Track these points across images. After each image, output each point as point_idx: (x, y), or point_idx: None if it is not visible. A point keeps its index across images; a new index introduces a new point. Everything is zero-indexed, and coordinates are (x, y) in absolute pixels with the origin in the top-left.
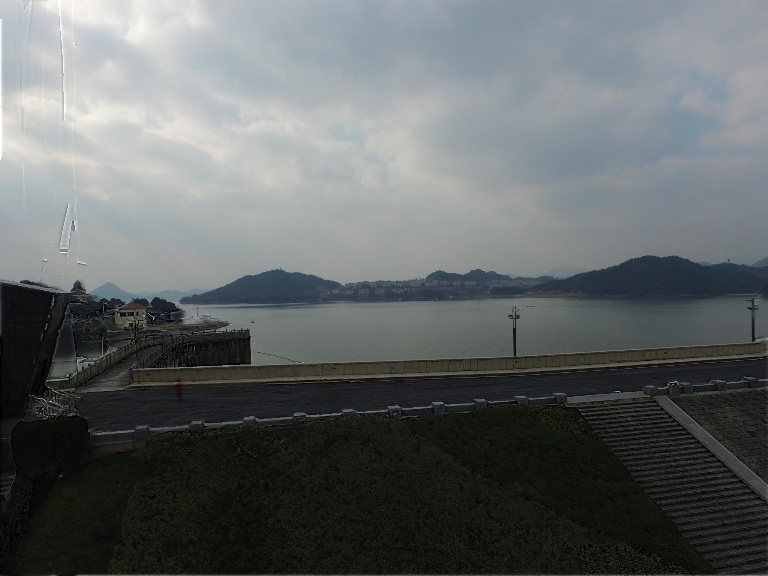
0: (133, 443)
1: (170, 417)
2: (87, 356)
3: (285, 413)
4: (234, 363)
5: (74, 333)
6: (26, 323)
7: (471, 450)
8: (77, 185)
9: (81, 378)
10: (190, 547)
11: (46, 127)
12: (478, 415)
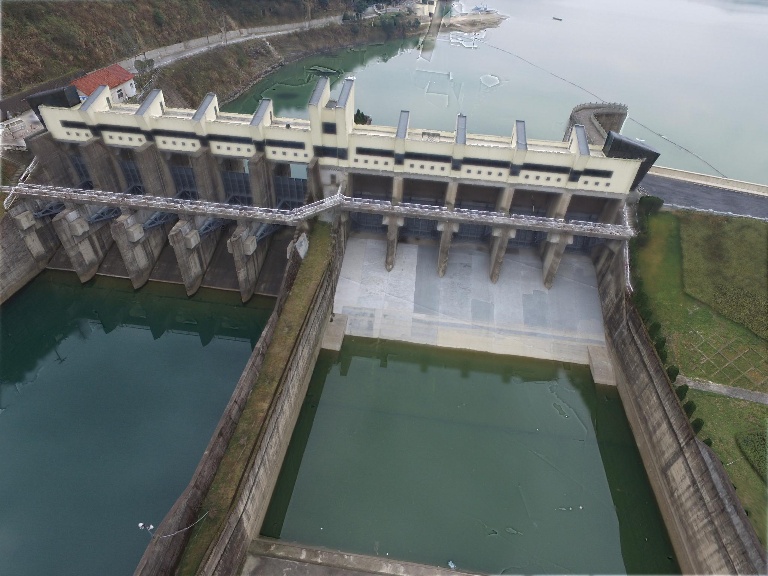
0: (671, 209)
1: (672, 198)
2: (407, 47)
3: (718, 208)
4: (613, 129)
5: (401, 25)
6: (647, 162)
7: None
8: None
9: None
10: (702, 247)
11: None
12: None
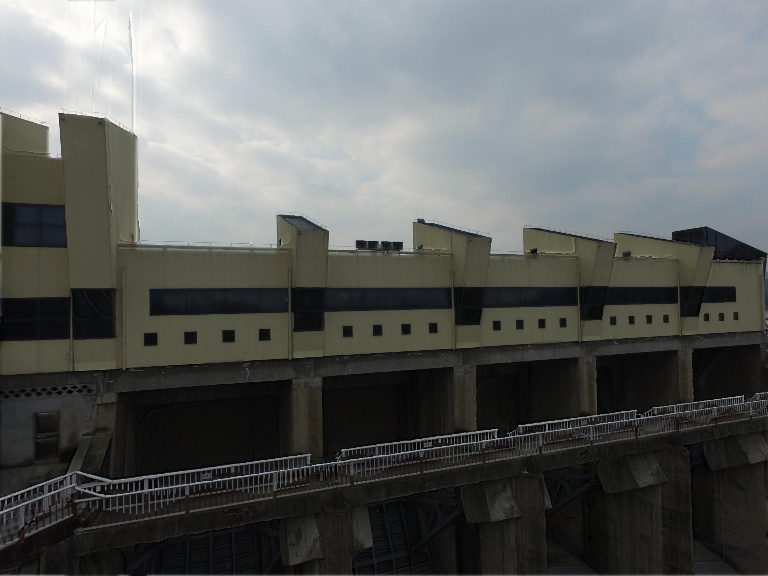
0: None
1: None
2: None
3: None
4: None
5: None
6: None
7: None
8: (140, 194)
9: None
10: None
11: None
12: None
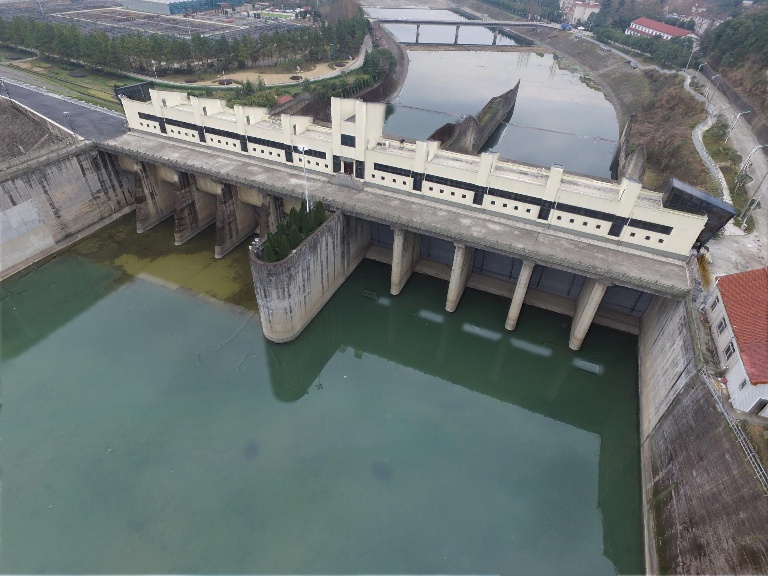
0: None
1: None
2: None
3: None
4: None
5: None
6: None
7: None
8: None
9: (81, 149)
10: None
11: None
12: None
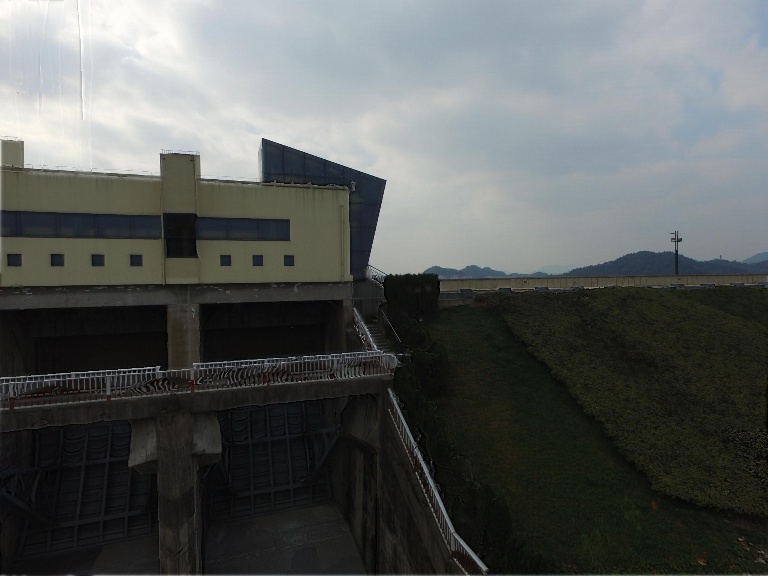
0: (463, 300)
1: None
2: None
3: None
4: None
5: None
6: (365, 205)
7: (733, 308)
8: None
9: None
10: (587, 348)
11: (63, 114)
12: (717, 290)
